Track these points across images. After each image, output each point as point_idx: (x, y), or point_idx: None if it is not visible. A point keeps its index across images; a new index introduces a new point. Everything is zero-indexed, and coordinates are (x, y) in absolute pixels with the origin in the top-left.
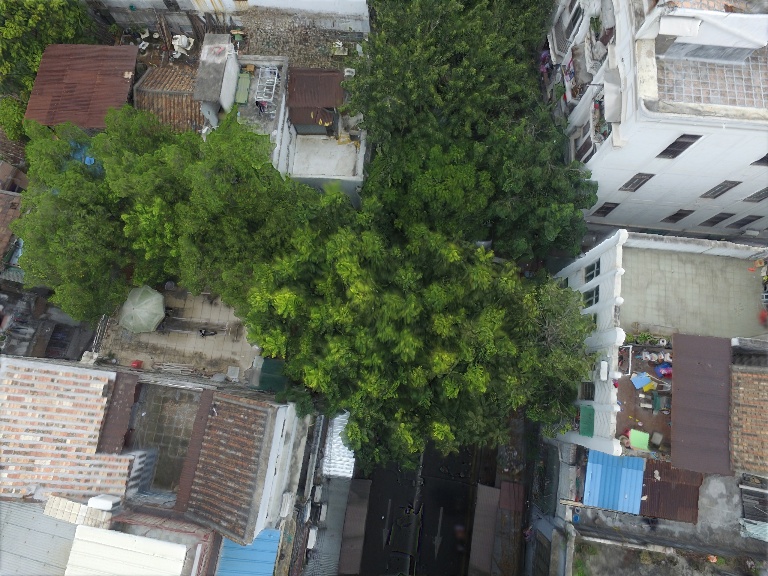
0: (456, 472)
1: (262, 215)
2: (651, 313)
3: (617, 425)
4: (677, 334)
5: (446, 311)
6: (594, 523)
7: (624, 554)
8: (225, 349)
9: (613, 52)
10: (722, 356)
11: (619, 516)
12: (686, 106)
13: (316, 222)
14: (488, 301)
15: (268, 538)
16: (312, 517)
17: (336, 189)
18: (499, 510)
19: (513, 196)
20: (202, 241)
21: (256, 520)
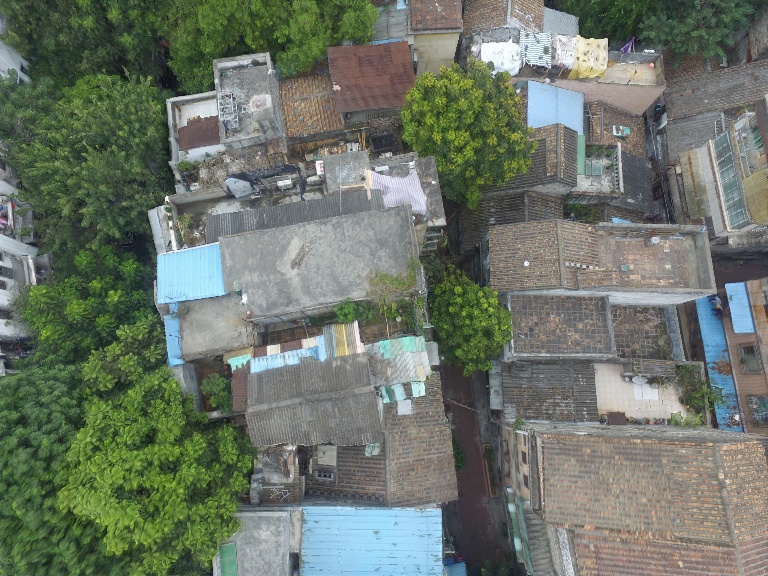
0: None
1: None
2: None
3: None
4: None
5: None
6: None
7: None
8: None
9: None
10: None
11: None
12: None
13: None
14: None
15: None
16: None
17: None
18: None
19: None
20: None
21: None
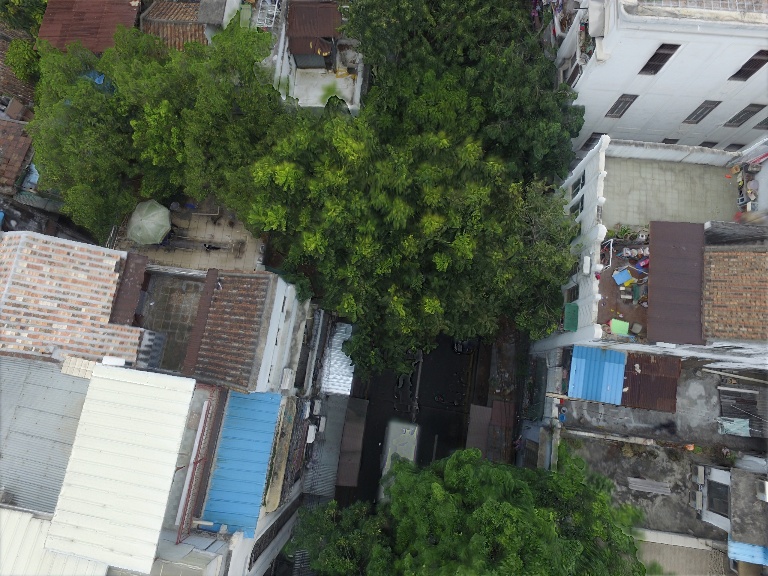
0: (450, 401)
1: (263, 128)
2: (632, 216)
3: (599, 318)
4: (654, 221)
5: (436, 189)
6: (579, 423)
7: (607, 449)
8: (228, 265)
9: None
10: (696, 239)
11: (603, 416)
12: (663, 10)
13: (315, 130)
14: (475, 182)
15: (270, 400)
16: (311, 422)
17: None
18: (491, 426)
19: (503, 120)
20: (206, 149)
21: (259, 371)
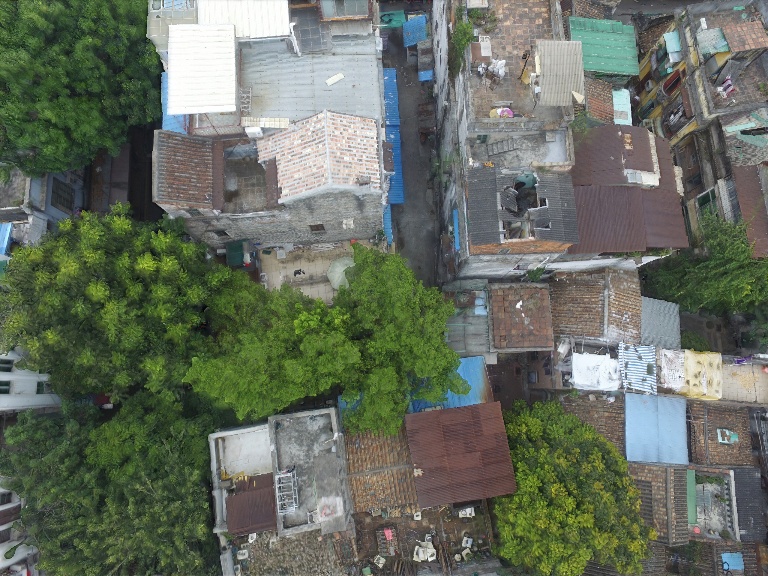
0: None
1: None
2: None
3: None
4: None
5: None
6: None
7: None
8: (292, 269)
9: None
10: None
11: None
12: None
13: None
14: None
15: None
16: None
17: None
18: None
19: None
20: None
21: None
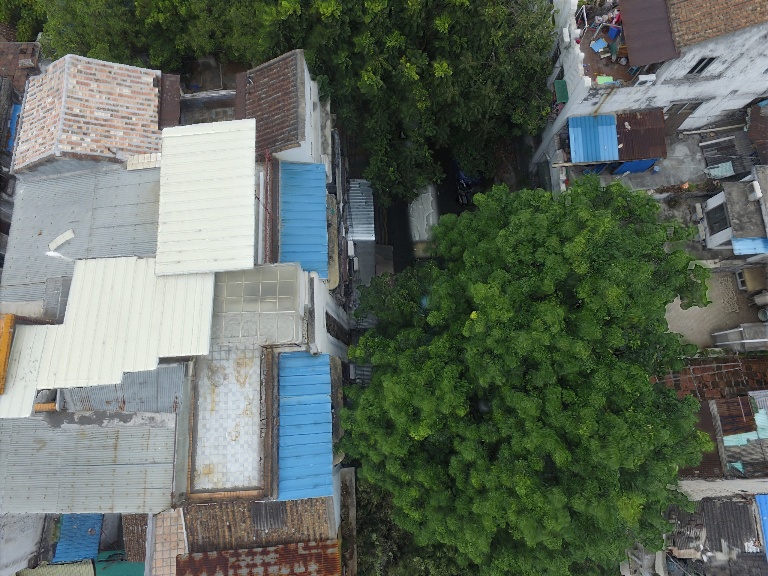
0: None
1: None
2: None
3: None
4: None
5: None
6: None
7: None
8: None
9: None
10: None
11: None
12: None
13: None
14: None
15: (316, 170)
16: None
17: None
18: None
19: None
20: None
21: None
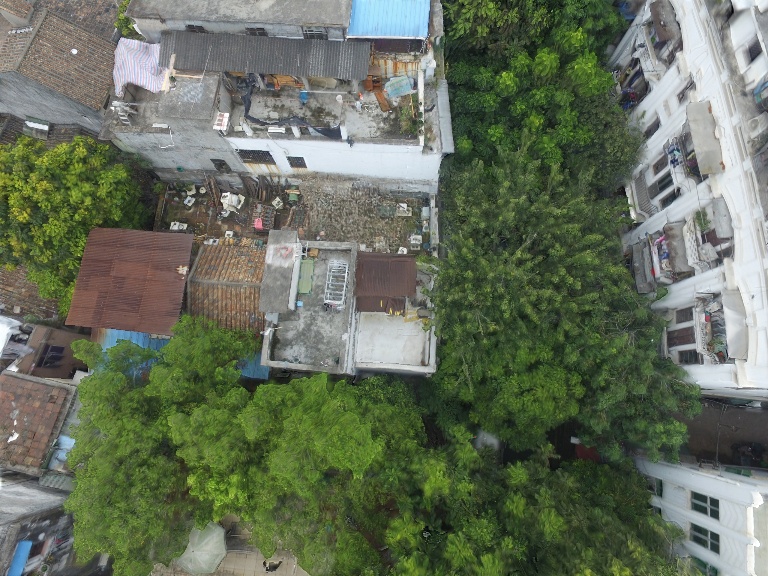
0: None
1: None
2: None
3: None
4: None
5: None
6: None
7: None
8: (289, 574)
9: (731, 268)
10: None
11: None
12: None
13: (405, 478)
14: None
15: None
16: None
17: (403, 371)
18: None
19: None
20: None
21: None
